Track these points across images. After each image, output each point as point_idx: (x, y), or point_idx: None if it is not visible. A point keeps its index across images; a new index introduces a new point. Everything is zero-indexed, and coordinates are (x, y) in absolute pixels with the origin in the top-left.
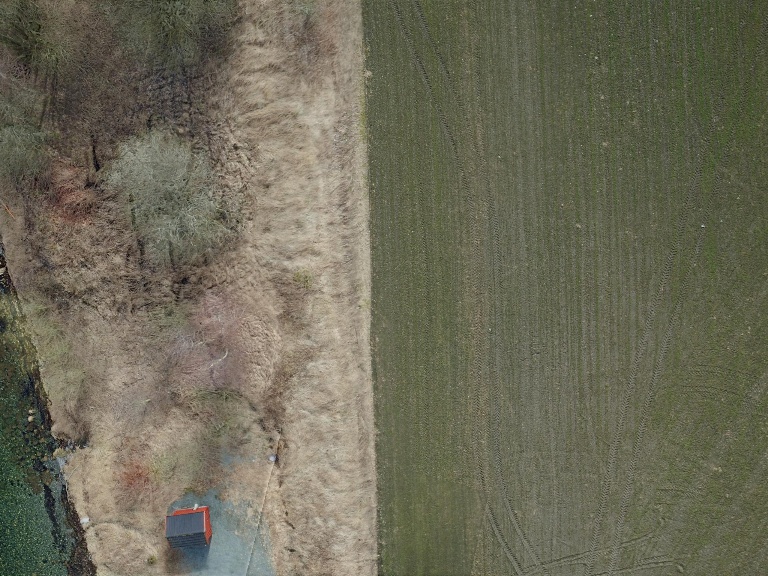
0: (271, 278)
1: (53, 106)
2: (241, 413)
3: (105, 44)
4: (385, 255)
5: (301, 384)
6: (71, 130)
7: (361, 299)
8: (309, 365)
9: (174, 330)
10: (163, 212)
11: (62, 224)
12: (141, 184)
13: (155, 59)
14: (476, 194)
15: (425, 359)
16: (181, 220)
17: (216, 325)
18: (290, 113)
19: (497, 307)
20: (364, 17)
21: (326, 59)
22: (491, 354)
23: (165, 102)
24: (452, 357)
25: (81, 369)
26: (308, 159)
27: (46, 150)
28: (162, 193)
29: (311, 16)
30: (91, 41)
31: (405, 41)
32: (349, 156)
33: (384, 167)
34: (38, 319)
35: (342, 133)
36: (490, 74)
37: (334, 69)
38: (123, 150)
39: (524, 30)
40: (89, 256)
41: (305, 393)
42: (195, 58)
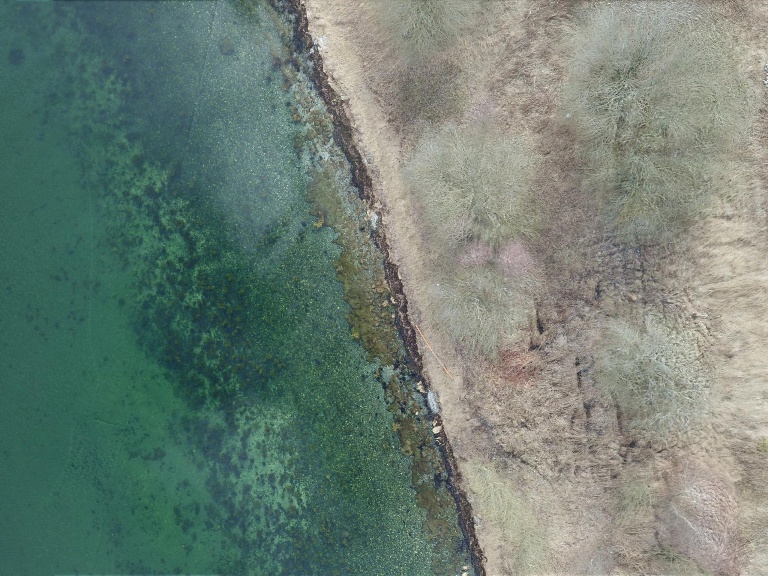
0: (729, 445)
1: None
2: (690, 575)
3: (552, 210)
4: None
5: (759, 550)
6: (513, 293)
7: None
8: None
9: (620, 492)
10: (641, 387)
11: (502, 385)
12: (589, 348)
13: (606, 226)
14: None
15: None
16: None
17: (664, 488)
18: (761, 287)
19: None
20: None
21: None
22: None
23: (616, 269)
24: None
25: (520, 528)
26: None
27: None
28: (648, 371)
29: None
30: (536, 206)
31: None
32: None
33: None
34: (475, 477)
35: None
36: None
37: None
38: (571, 315)
39: None
40: (530, 417)
41: (763, 559)
42: (650, 227)
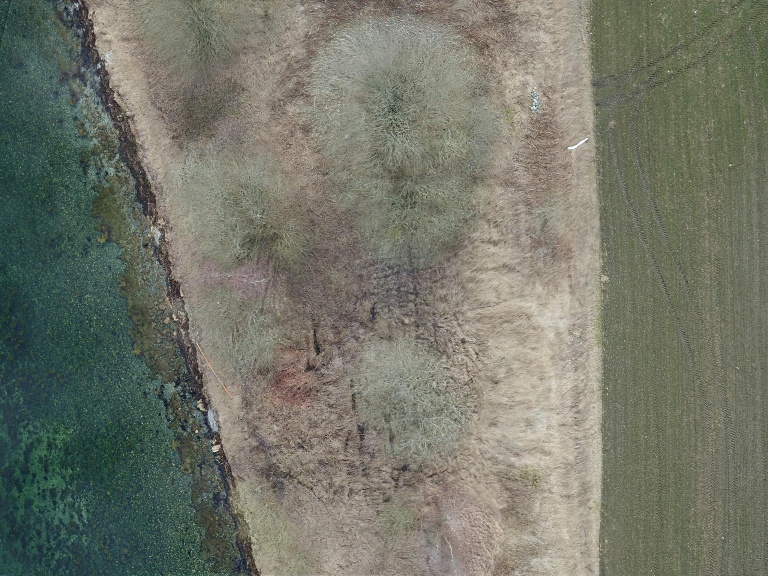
0: (496, 472)
1: (274, 289)
2: None
3: (330, 230)
4: (617, 458)
5: None
6: (292, 313)
7: (591, 501)
8: (533, 561)
9: (392, 516)
10: (399, 412)
11: (280, 405)
12: (363, 371)
13: (381, 248)
14: (712, 403)
15: (655, 563)
16: (423, 427)
17: (435, 513)
18: (524, 314)
19: (731, 516)
20: (602, 222)
21: (563, 263)
22: (723, 562)
23: (390, 291)
24: (683, 563)
25: (295, 549)
26: (541, 360)
27: (267, 333)
28: None
29: (549, 220)
30: (315, 226)
31: (644, 248)
32: (583, 359)
33: (618, 372)
34: (252, 497)
35: (576, 336)
36: (730, 285)
37: (570, 273)
38: (346, 336)
39: (767, 244)
40: (306, 438)
41: None
42: None
